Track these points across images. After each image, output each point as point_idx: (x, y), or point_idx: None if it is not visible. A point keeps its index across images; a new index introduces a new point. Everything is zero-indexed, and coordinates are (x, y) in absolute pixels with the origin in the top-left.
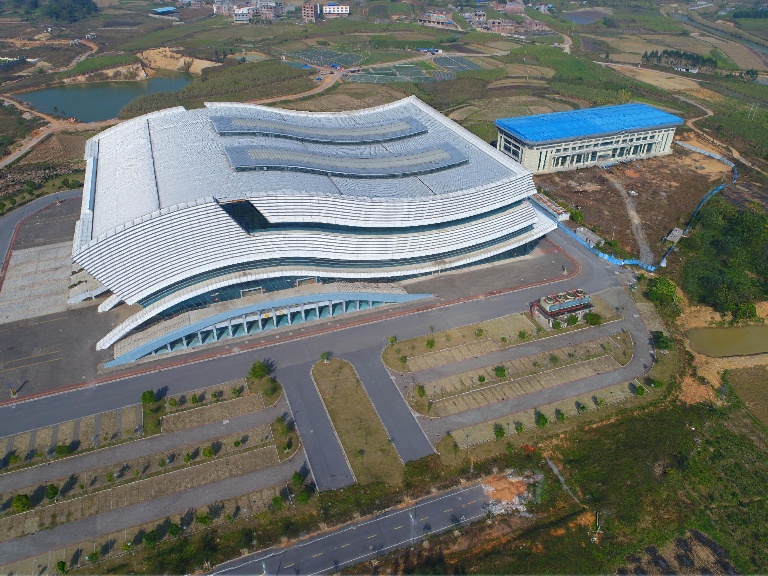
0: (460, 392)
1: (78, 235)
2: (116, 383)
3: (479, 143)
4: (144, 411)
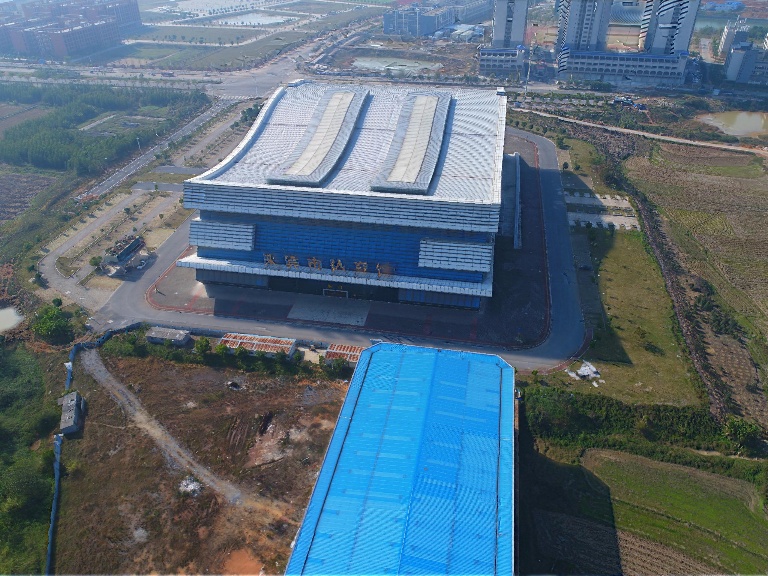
0: (143, 204)
1: None
2: None
3: None
4: None
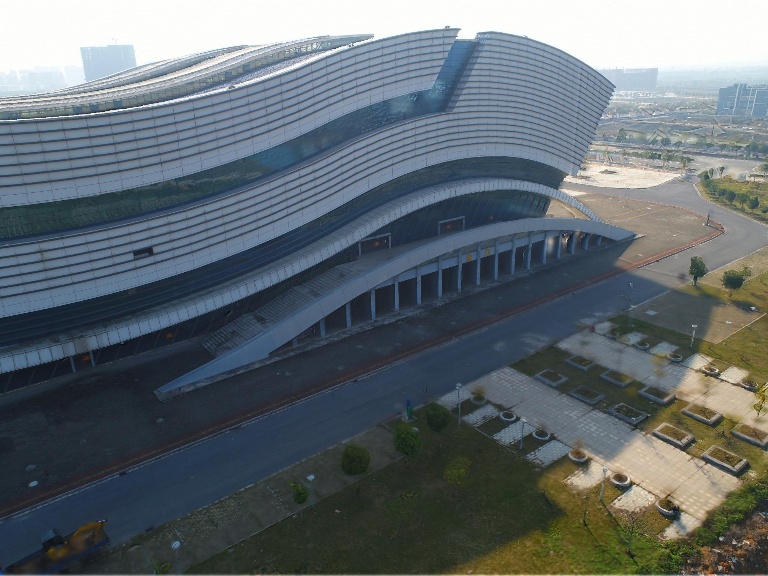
0: None
1: None
2: None
3: None
4: None
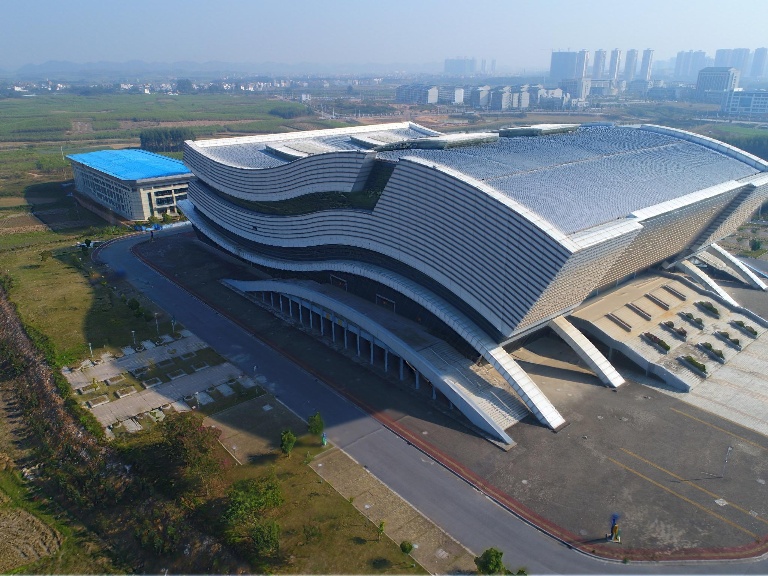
0: None
1: (767, 177)
2: (767, 271)
3: (354, 129)
4: (759, 255)
